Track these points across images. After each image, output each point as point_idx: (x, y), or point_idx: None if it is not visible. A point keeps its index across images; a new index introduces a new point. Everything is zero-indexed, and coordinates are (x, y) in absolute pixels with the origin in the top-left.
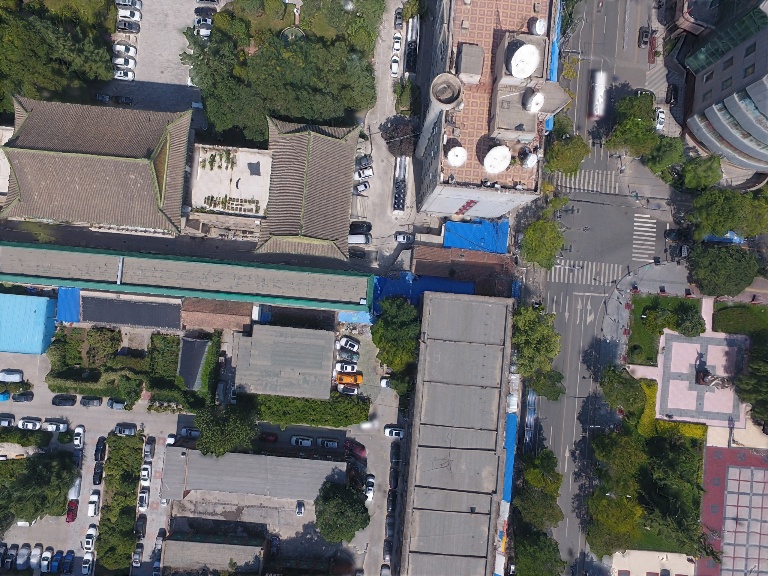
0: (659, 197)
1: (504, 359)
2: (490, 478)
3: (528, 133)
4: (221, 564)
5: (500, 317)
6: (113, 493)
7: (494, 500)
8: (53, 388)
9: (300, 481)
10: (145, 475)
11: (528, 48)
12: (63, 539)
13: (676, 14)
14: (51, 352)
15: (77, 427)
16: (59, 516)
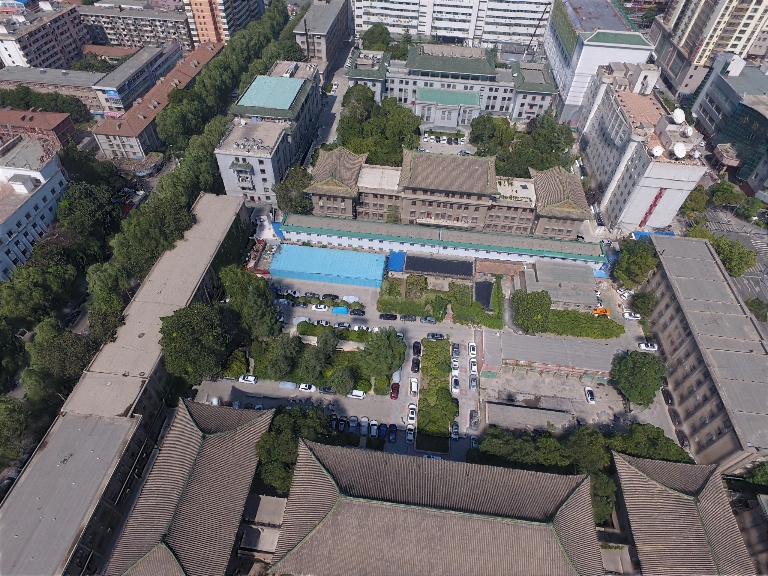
0: (761, 233)
1: (720, 266)
2: (752, 332)
3: (690, 143)
4: (540, 425)
5: (704, 248)
6: (428, 380)
7: (765, 344)
8: (380, 309)
9: (594, 356)
10: (456, 365)
11: (679, 110)
12: (386, 414)
13: (720, 159)
14: (386, 282)
15: (398, 333)
16: (383, 395)
